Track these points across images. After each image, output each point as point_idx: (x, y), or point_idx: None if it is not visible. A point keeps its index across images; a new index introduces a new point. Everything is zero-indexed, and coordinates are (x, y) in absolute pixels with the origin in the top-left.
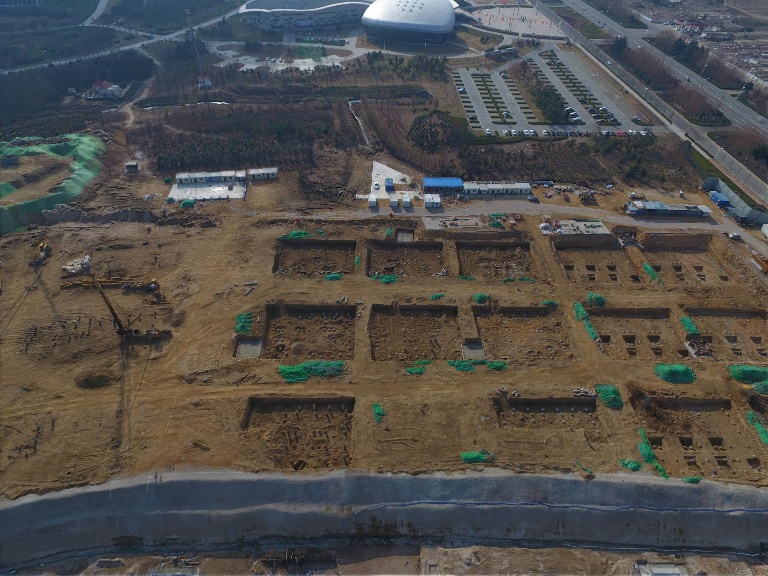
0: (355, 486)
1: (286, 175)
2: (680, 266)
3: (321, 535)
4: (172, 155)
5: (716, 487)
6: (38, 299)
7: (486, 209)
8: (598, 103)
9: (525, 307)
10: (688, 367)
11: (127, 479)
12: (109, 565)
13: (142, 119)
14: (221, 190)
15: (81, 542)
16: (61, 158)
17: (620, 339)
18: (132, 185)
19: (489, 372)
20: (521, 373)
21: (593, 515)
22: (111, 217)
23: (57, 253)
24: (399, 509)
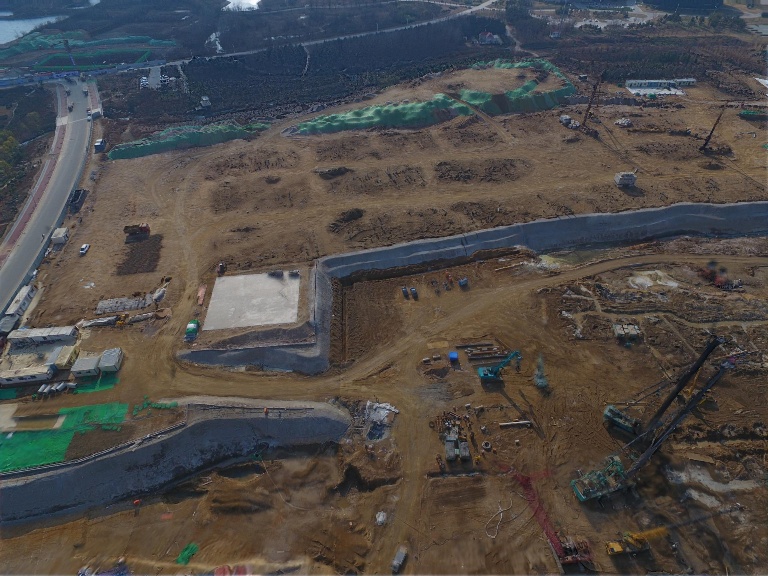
0: None
1: (699, 84)
2: None
3: None
4: None
5: None
6: (622, 136)
7: None
8: None
9: None
10: None
11: None
12: None
13: None
14: (664, 90)
15: None
16: None
17: None
18: None
19: None
20: None
21: None
22: (609, 102)
23: (599, 117)
24: None
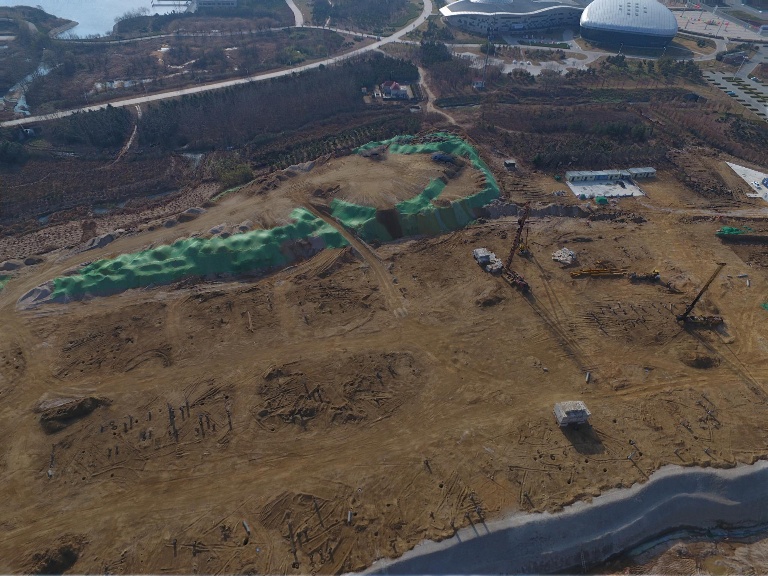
0: None
1: (660, 174)
2: None
3: None
4: None
5: None
6: (563, 287)
7: None
8: None
9: None
10: None
11: None
12: None
13: (462, 119)
14: (616, 188)
15: None
16: None
17: None
18: (529, 182)
19: None
20: None
21: None
22: (544, 212)
23: (531, 245)
24: None
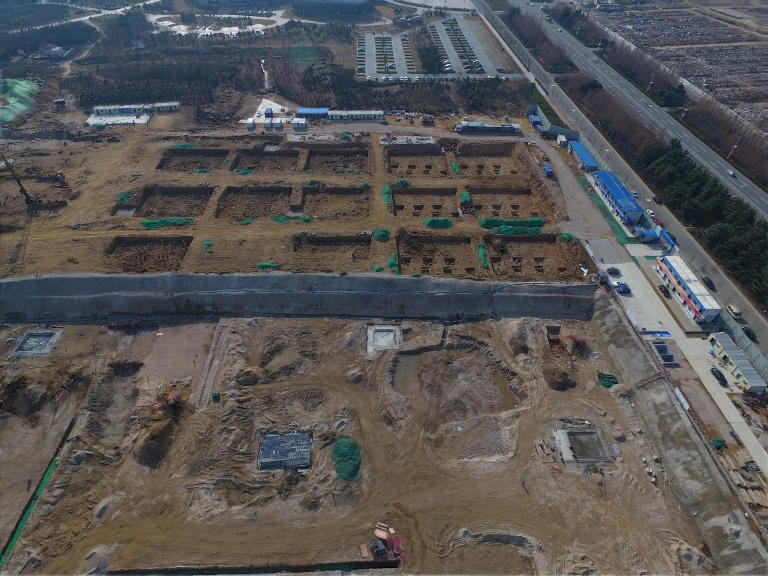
0: (177, 281)
1: (187, 108)
2: (483, 165)
3: (151, 312)
4: (94, 94)
5: (431, 279)
6: None
7: (342, 129)
8: (474, 58)
9: (345, 188)
10: (449, 219)
11: (16, 278)
12: (0, 328)
13: (77, 72)
14: (130, 118)
15: None
16: (0, 96)
17: (411, 207)
18: (57, 115)
19: (299, 223)
20: (323, 223)
21: (342, 297)
22: (36, 136)
23: None
24: (207, 295)
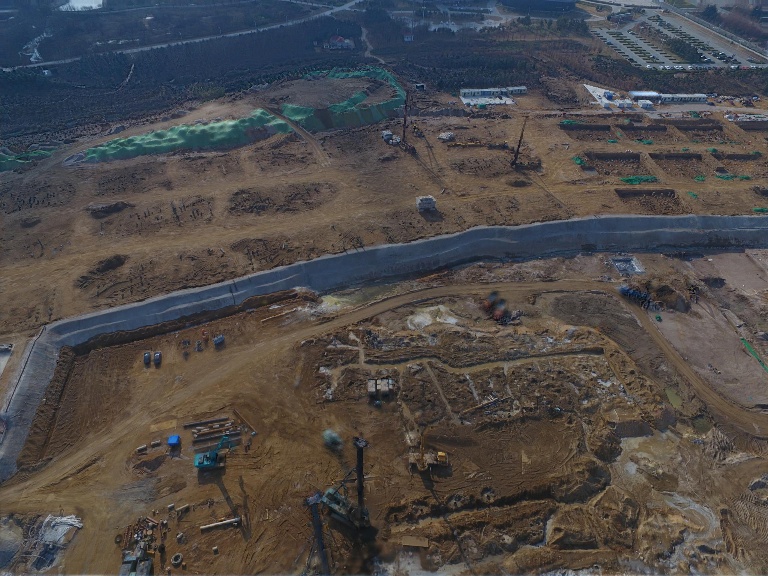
0: (703, 221)
1: (531, 92)
2: None
3: (690, 244)
4: None
5: None
6: (440, 151)
7: (683, 109)
8: (716, 50)
9: (742, 154)
10: None
11: None
12: (587, 255)
13: (390, 61)
14: (495, 99)
15: (567, 246)
16: None
17: None
18: (432, 97)
19: (742, 180)
20: (761, 180)
21: None
22: (438, 113)
23: (424, 131)
24: (729, 231)
